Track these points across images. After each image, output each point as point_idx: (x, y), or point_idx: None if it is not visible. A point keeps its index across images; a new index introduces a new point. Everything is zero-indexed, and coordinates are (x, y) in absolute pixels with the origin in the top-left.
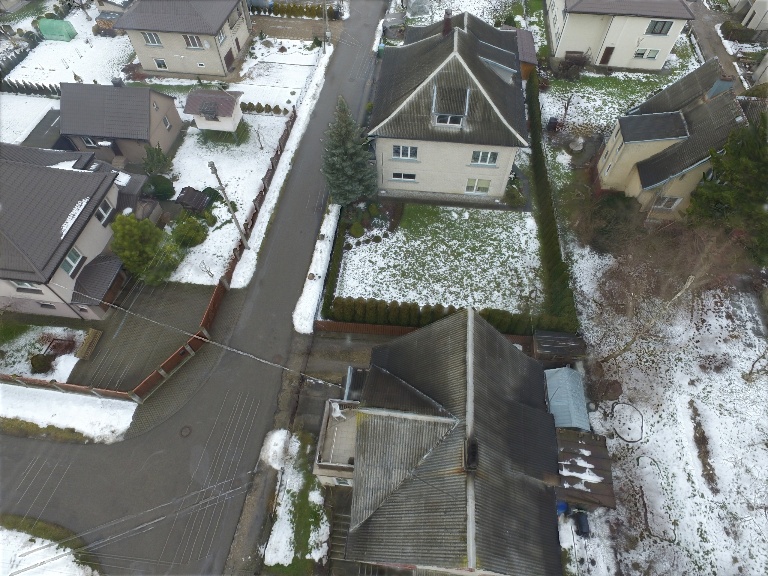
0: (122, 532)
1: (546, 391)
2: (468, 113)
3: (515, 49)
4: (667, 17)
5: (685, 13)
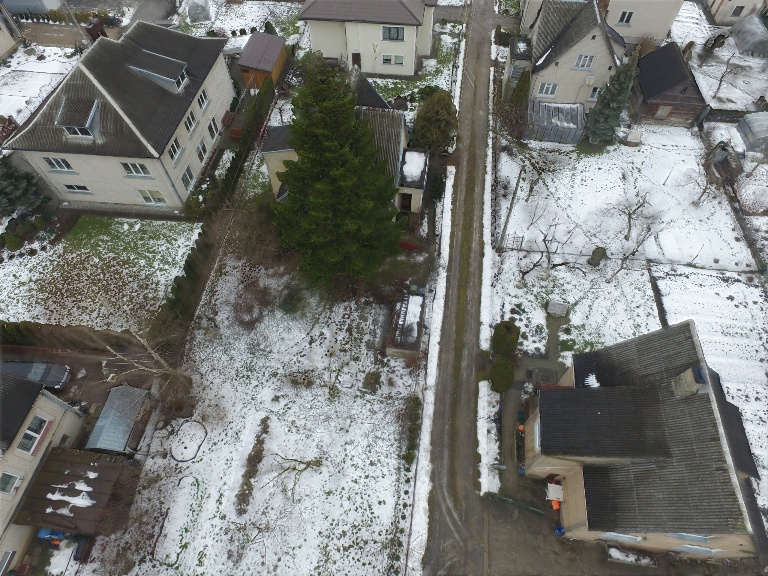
0: None
1: (102, 410)
2: (100, 124)
3: (212, 57)
4: (394, 23)
5: (411, 19)
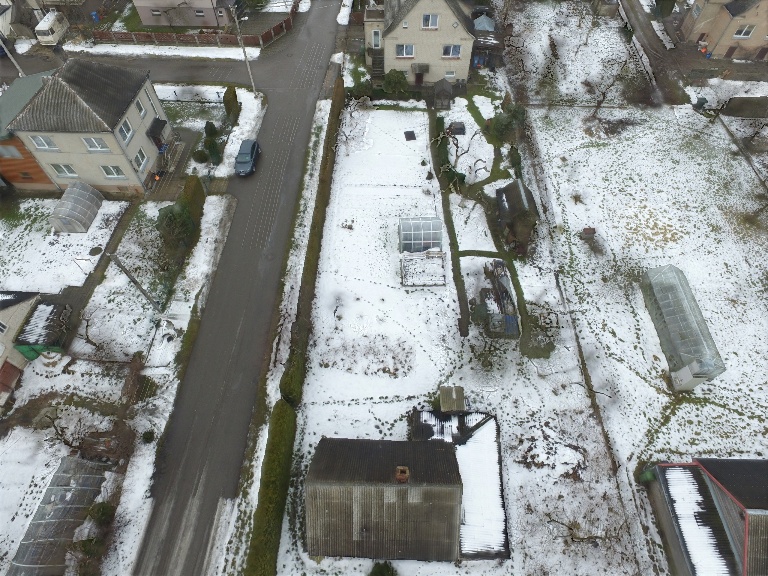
0: (294, 4)
1: (474, 27)
2: None
3: None
4: None
5: None
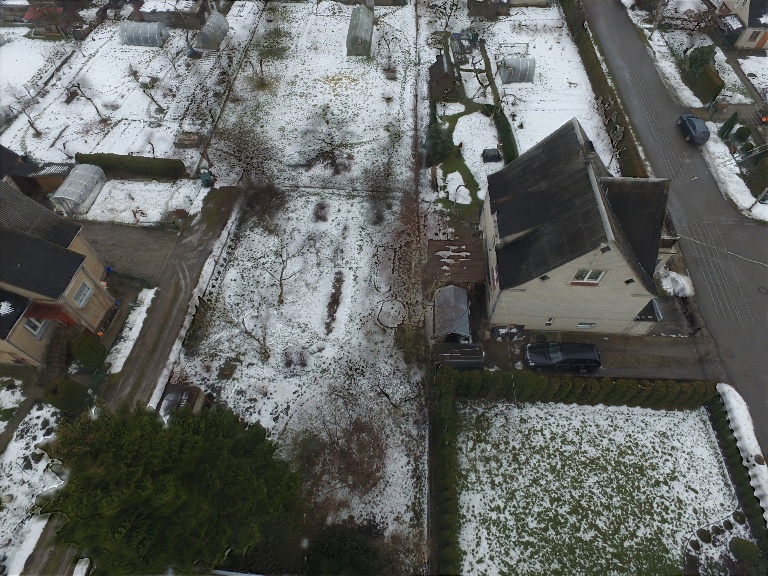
0: None
1: None
2: None
3: None
4: None
5: None
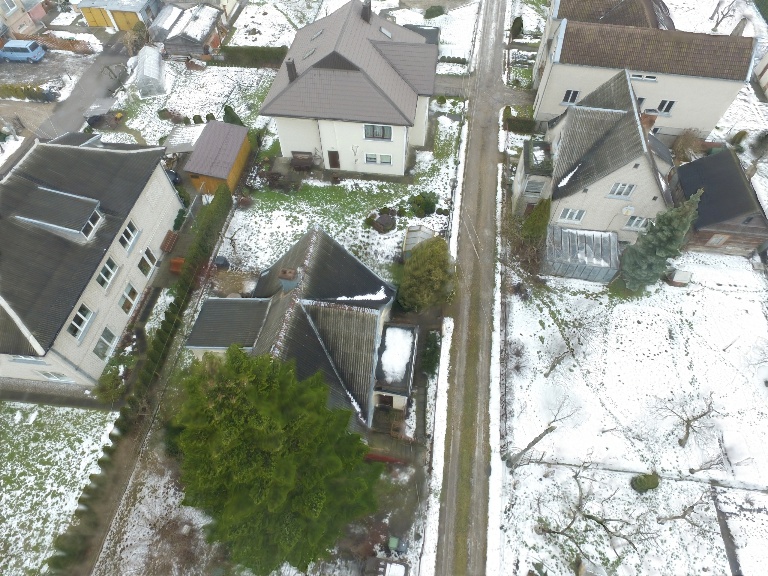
0: None
1: None
2: None
3: (141, 179)
4: (378, 122)
5: (399, 118)
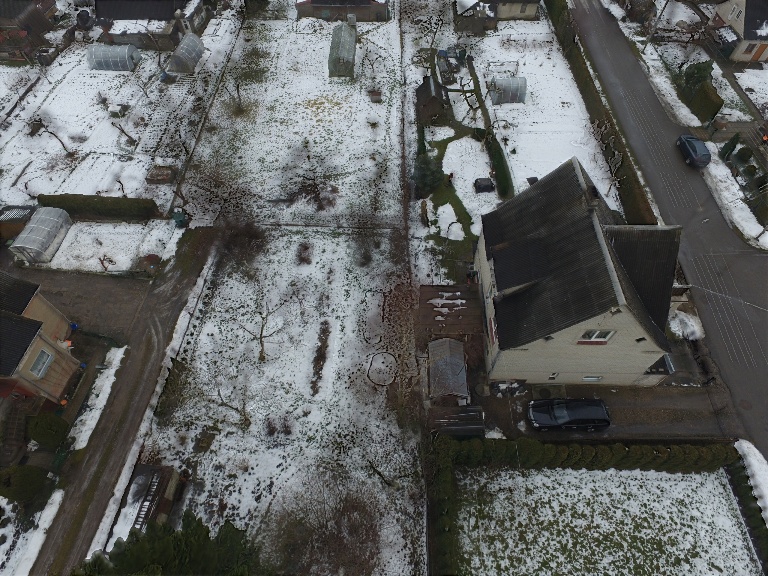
0: None
1: None
2: None
3: None
4: None
5: None
